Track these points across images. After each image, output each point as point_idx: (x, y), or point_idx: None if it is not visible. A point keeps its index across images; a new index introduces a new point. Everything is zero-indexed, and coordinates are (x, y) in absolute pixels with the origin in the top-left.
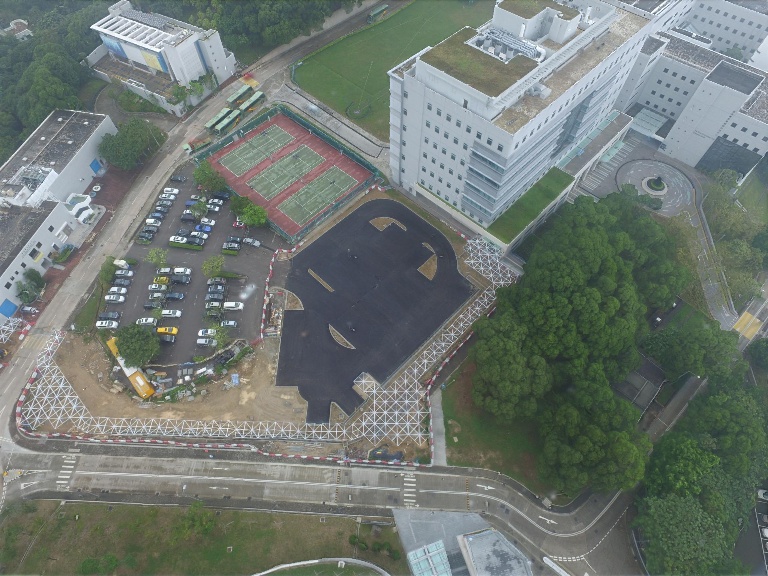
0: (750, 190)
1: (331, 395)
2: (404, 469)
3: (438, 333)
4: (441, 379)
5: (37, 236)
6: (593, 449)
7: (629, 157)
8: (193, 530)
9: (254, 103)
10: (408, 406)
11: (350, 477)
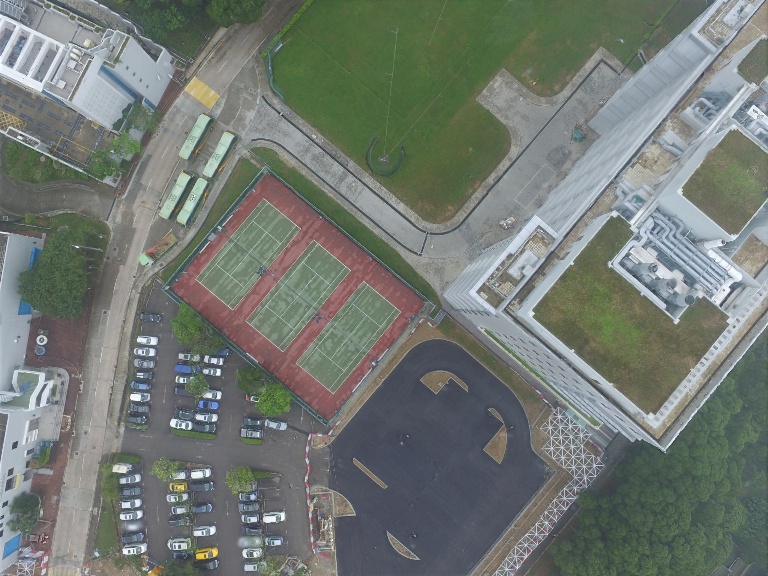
0: None
1: None
2: None
3: (508, 532)
4: None
5: (3, 468)
6: None
7: None
8: None
9: (224, 158)
10: None
11: None
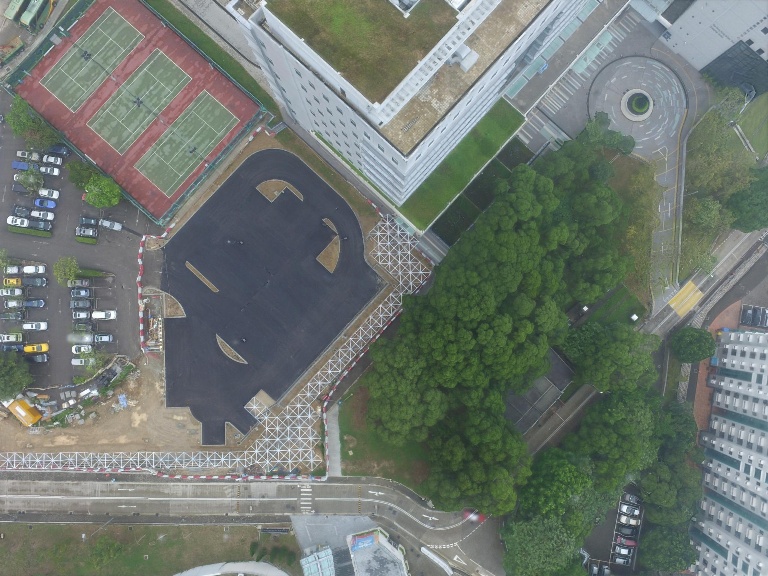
0: (761, 102)
1: (225, 415)
2: (301, 481)
3: (337, 341)
4: (339, 393)
5: None
6: (471, 487)
7: (617, 52)
8: (102, 564)
9: None
10: (301, 432)
11: (249, 491)
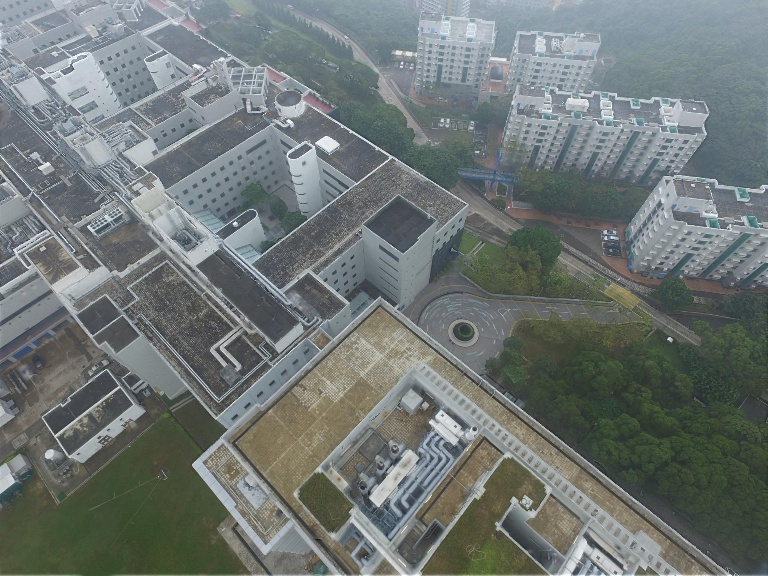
0: None
1: None
2: None
3: None
4: None
5: None
6: None
7: None
8: None
9: None
10: None
11: None
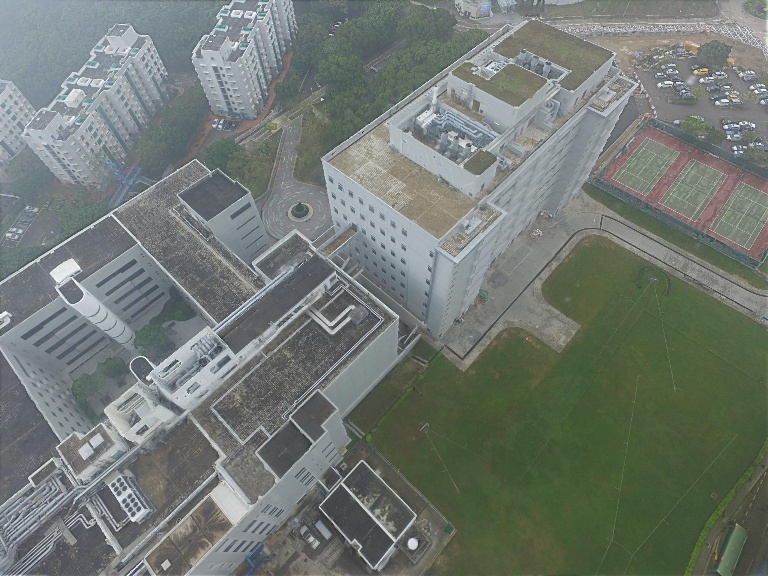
0: None
1: None
2: None
3: None
4: None
5: None
6: None
7: None
8: None
9: None
10: None
11: None
